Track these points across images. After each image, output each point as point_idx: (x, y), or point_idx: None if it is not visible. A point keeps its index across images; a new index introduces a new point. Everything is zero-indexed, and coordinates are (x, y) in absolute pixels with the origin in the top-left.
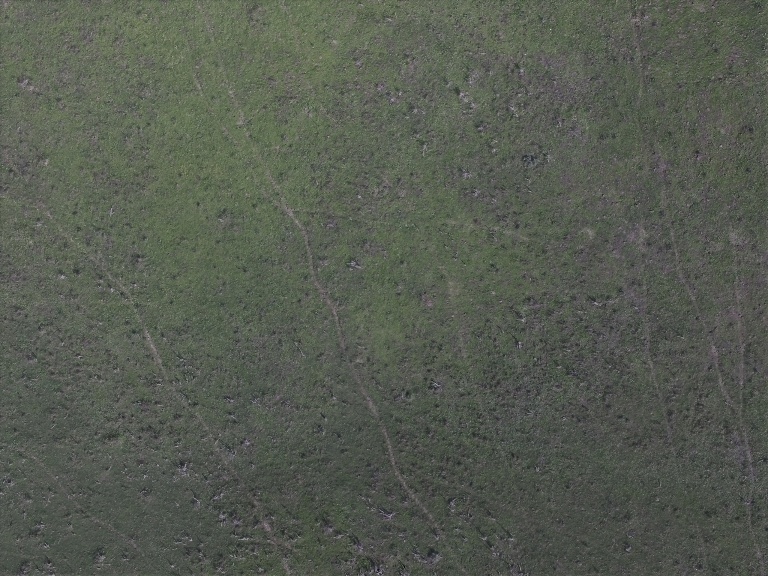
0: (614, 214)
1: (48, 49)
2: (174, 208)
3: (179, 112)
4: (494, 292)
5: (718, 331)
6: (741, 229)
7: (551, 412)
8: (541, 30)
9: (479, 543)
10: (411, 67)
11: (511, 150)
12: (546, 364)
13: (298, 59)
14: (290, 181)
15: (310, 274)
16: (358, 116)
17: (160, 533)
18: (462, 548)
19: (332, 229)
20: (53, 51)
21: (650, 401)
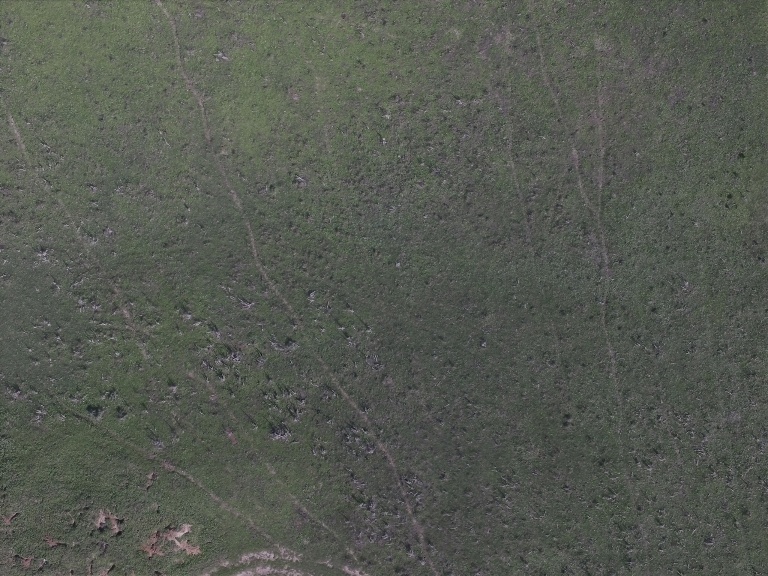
0: (481, 15)
1: None
2: None
3: None
4: (360, 88)
5: (579, 134)
6: (606, 35)
7: (413, 210)
8: None
9: (337, 334)
10: None
11: None
12: (410, 161)
13: None
14: None
15: (177, 64)
16: None
17: (19, 317)
18: (320, 338)
19: (200, 20)
20: None
21: (510, 200)
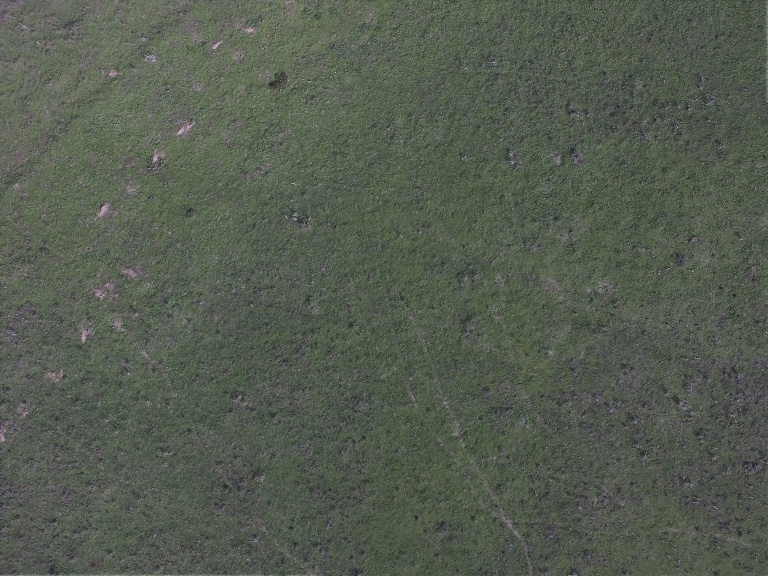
0: None
1: (260, 363)
2: (391, 522)
3: (394, 425)
4: None
5: None
6: None
7: None
8: (757, 333)
9: None
10: (629, 377)
11: (731, 457)
12: None
13: (513, 369)
14: (508, 492)
15: None
16: (576, 426)
17: None
18: None
19: (552, 540)
20: (265, 365)
21: None
